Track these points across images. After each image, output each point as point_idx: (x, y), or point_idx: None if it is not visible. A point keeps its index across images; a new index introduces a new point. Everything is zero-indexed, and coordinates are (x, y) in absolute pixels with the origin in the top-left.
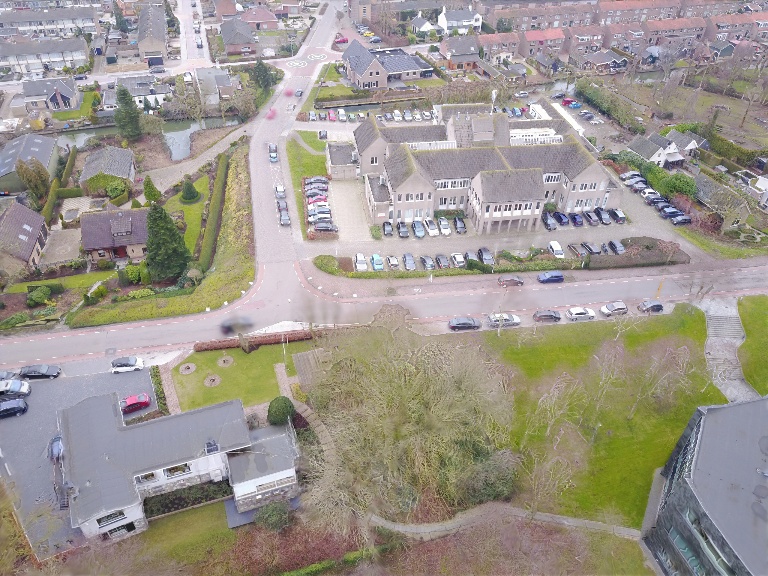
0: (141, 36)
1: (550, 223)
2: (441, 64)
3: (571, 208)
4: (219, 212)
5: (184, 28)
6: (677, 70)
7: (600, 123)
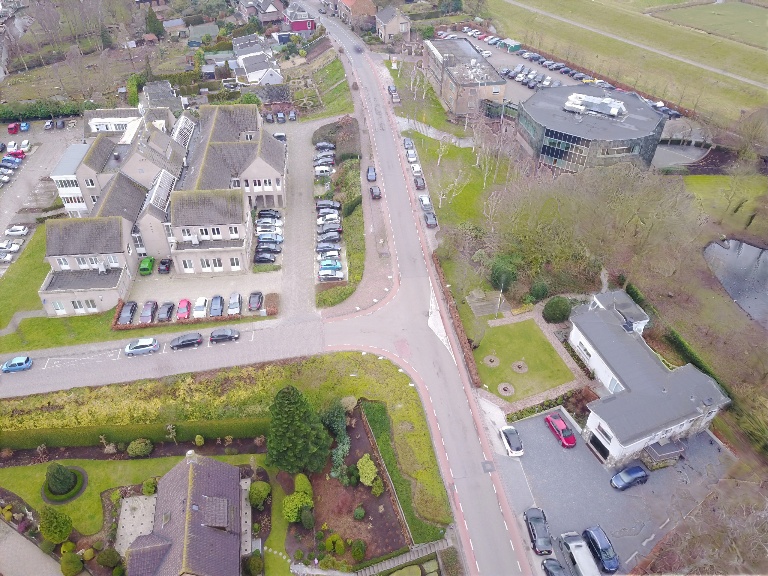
0: None
1: None
2: None
3: None
4: None
5: None
6: None
7: (76, 123)
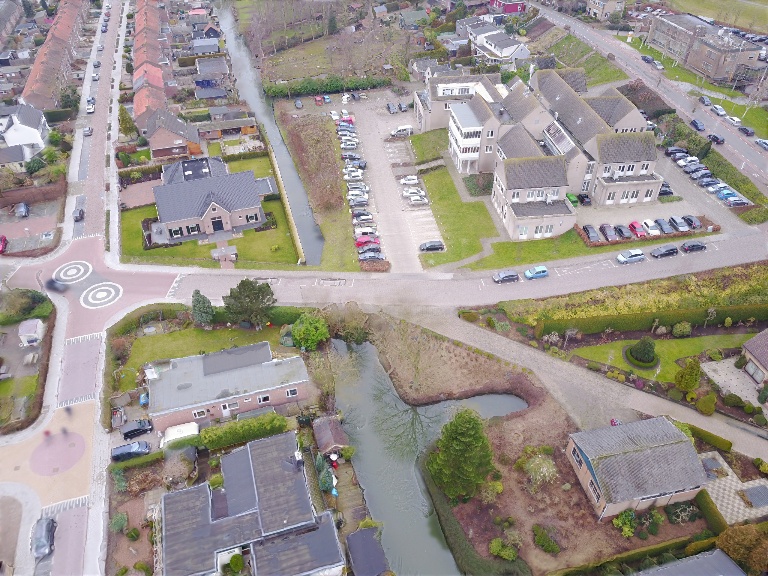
0: None
1: None
2: None
3: None
4: None
5: None
6: None
7: (367, 95)
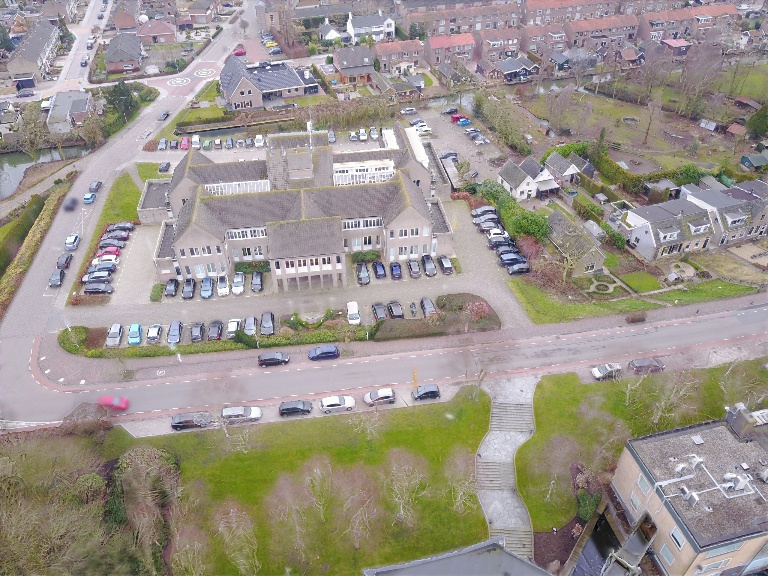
0: (12, 57)
1: (362, 276)
2: (332, 78)
3: (395, 256)
4: (6, 266)
5: (78, 44)
6: (600, 75)
7: (485, 143)
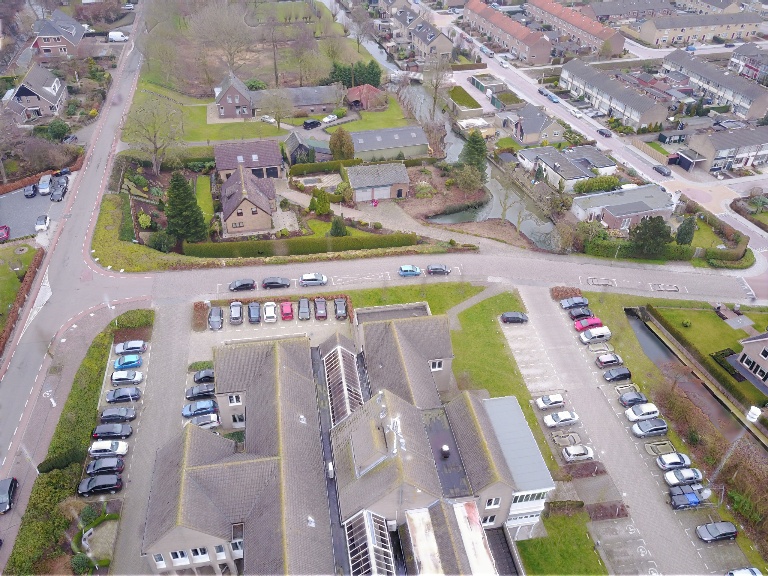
0: None
1: None
2: None
3: None
4: None
5: None
6: None
7: None
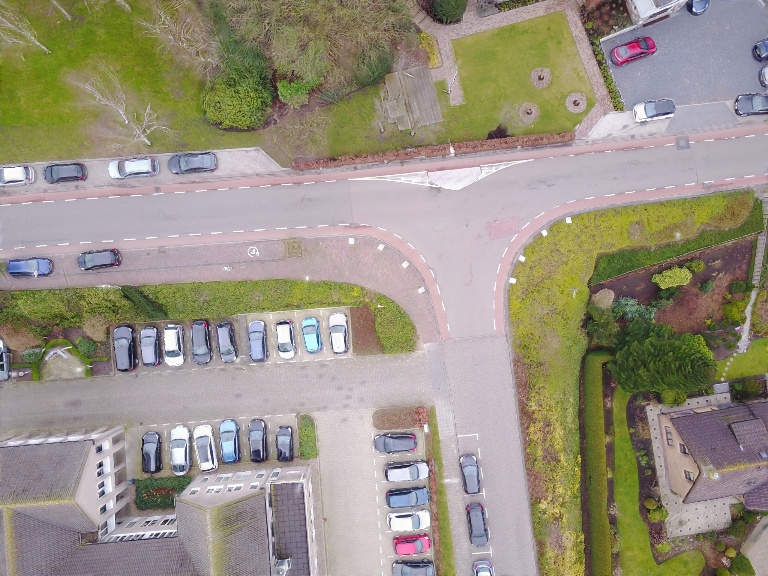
0: None
1: None
2: None
3: None
4: (591, 552)
5: None
6: None
7: None
